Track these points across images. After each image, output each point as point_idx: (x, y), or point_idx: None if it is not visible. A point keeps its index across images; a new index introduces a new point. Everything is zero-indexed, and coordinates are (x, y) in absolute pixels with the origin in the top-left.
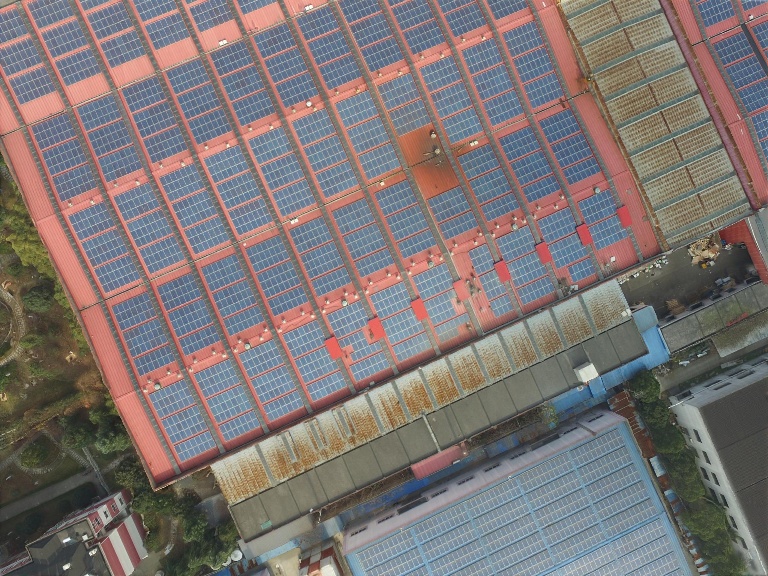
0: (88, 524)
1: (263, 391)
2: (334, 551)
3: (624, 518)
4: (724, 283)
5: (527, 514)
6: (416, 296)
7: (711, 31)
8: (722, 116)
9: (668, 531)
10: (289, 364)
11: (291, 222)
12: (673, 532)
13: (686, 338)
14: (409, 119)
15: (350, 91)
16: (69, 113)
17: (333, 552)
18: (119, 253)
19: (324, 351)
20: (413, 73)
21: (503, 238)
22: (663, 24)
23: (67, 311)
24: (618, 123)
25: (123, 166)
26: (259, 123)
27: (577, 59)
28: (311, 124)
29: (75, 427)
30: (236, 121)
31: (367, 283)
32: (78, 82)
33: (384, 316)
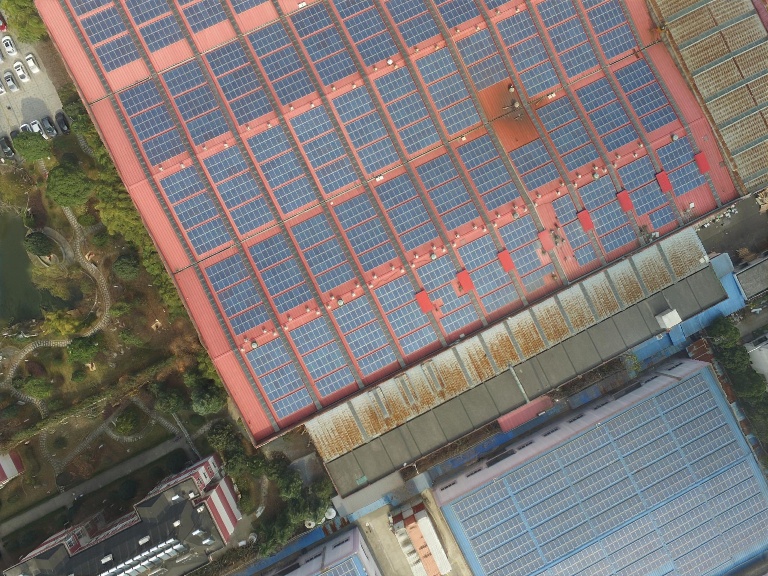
0: (194, 482)
1: (357, 347)
2: (425, 506)
3: (712, 461)
4: None
5: (617, 460)
6: (502, 248)
7: None
8: None
9: (755, 472)
10: (381, 319)
11: (376, 179)
12: (760, 473)
13: (762, 283)
14: (488, 74)
15: (429, 48)
16: (155, 79)
17: (425, 507)
18: (210, 216)
19: (415, 305)
20: (490, 28)
21: (585, 188)
22: None
23: (156, 278)
24: (691, 71)
25: (211, 129)
26: (342, 83)
27: (649, 9)
28: (392, 82)
29: (167, 392)
30: (319, 81)
31: (454, 236)
32: (162, 49)
33: (472, 269)
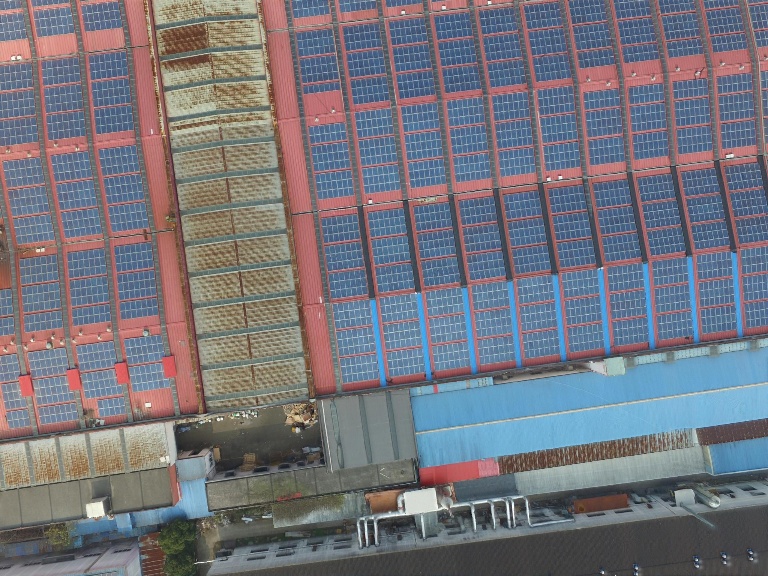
0: None
1: None
2: None
3: None
4: (311, 452)
5: None
6: None
7: (324, 204)
8: (299, 295)
9: None
10: None
11: None
12: None
13: (230, 500)
14: None
15: None
16: None
17: None
18: None
19: None
20: None
21: (36, 353)
22: (274, 184)
23: None
24: (195, 271)
25: None
26: None
27: None
28: None
29: None
30: None
31: None
32: None
33: None
